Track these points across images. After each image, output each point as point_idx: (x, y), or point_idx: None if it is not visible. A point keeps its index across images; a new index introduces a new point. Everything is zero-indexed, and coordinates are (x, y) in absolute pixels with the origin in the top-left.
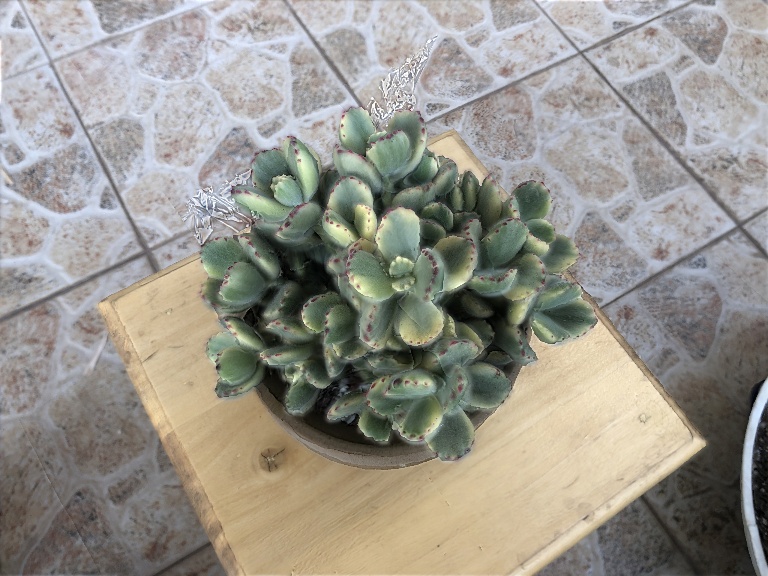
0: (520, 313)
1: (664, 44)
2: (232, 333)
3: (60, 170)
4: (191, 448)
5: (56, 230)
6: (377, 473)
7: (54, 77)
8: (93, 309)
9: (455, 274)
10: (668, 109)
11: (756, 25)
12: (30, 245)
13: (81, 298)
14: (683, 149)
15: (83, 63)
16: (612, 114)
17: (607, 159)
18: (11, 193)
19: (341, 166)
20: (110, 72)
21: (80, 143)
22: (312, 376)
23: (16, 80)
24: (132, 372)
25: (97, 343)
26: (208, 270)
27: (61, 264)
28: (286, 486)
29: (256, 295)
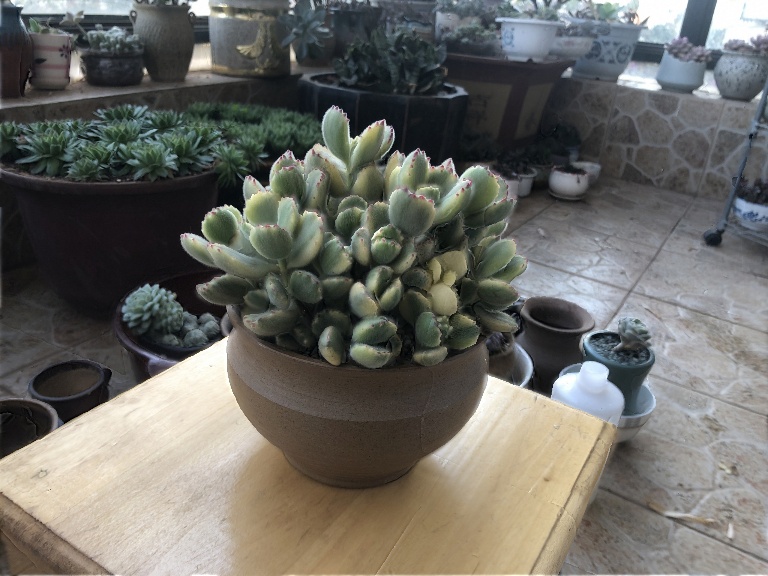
0: None
1: None
2: None
3: None
4: None
5: None
6: None
7: None
8: None
9: None
10: None
11: None
12: None
13: None
14: None
15: None
16: None
17: None
18: None
19: None
20: None
21: None
22: None
23: None
24: None
25: None
26: None
27: None
28: None
29: None
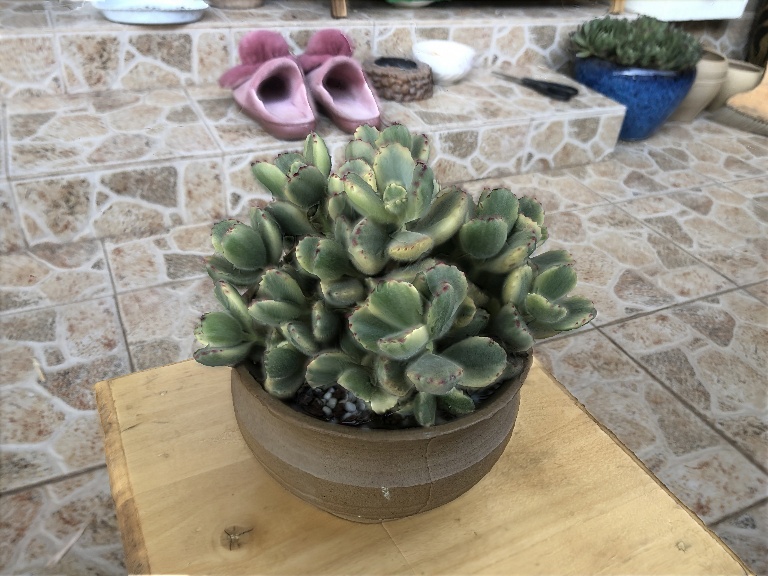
0: (513, 282)
1: (676, 328)
2: (225, 291)
3: (93, 375)
4: (147, 515)
5: (70, 424)
6: (357, 566)
7: (114, 305)
8: (79, 500)
9: (447, 217)
10: (688, 378)
11: (762, 321)
12: (39, 434)
13: (71, 488)
14: (709, 413)
15: (143, 298)
16: (632, 377)
17: (631, 414)
18: (40, 388)
19: (351, 155)
20: (164, 306)
21: (119, 355)
22: (296, 331)
23: (80, 304)
24: (108, 441)
25: (71, 535)
26: (215, 244)
27: (63, 454)
28: (246, 567)
29: (255, 263)
